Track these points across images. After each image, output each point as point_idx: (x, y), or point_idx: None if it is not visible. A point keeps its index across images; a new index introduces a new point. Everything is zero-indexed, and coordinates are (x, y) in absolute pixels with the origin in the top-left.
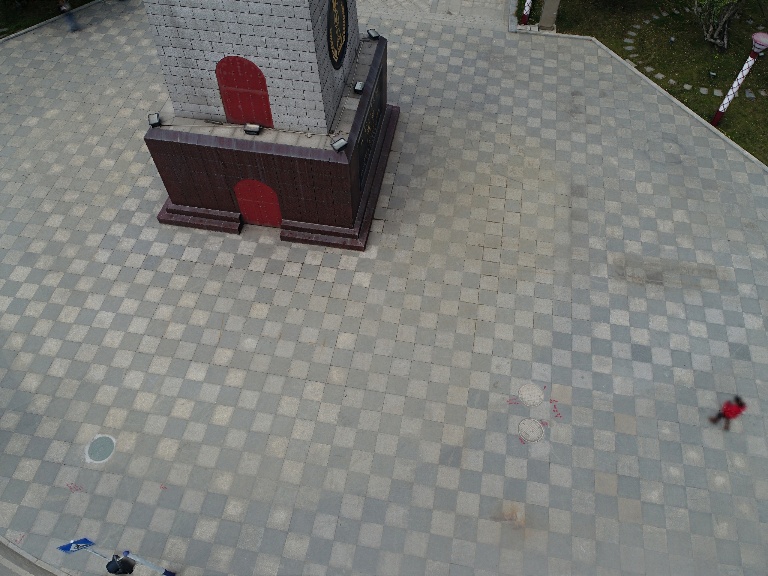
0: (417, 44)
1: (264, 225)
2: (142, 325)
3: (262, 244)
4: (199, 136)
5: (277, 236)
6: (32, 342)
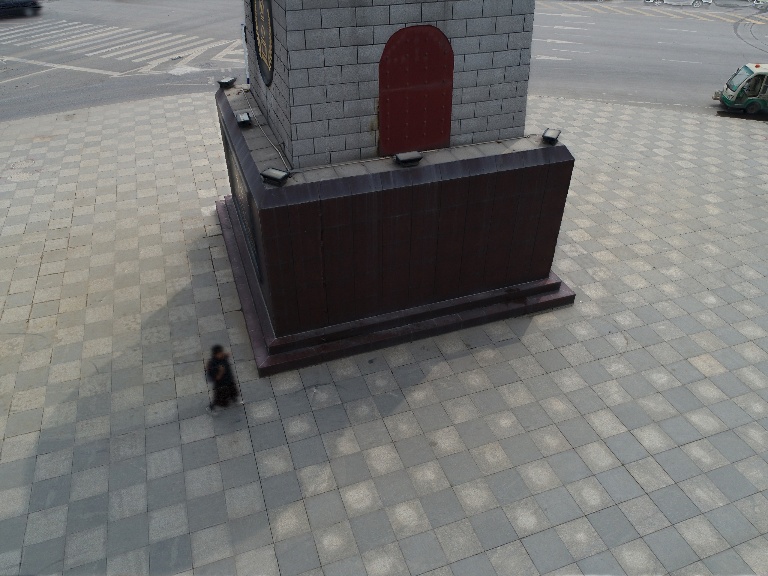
0: None
1: None
2: None
3: None
4: None
5: None
6: None
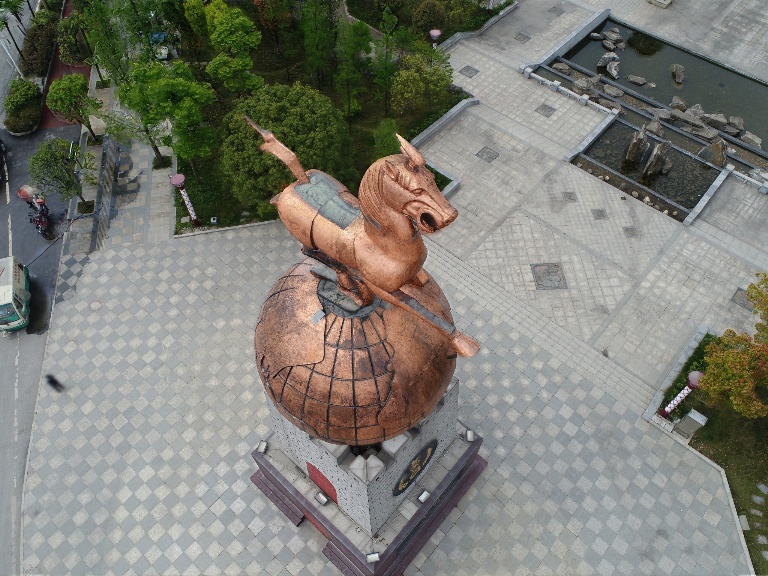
0: (547, 389)
1: None
2: (193, 575)
3: (308, 548)
4: (285, 479)
5: (322, 546)
6: (125, 543)
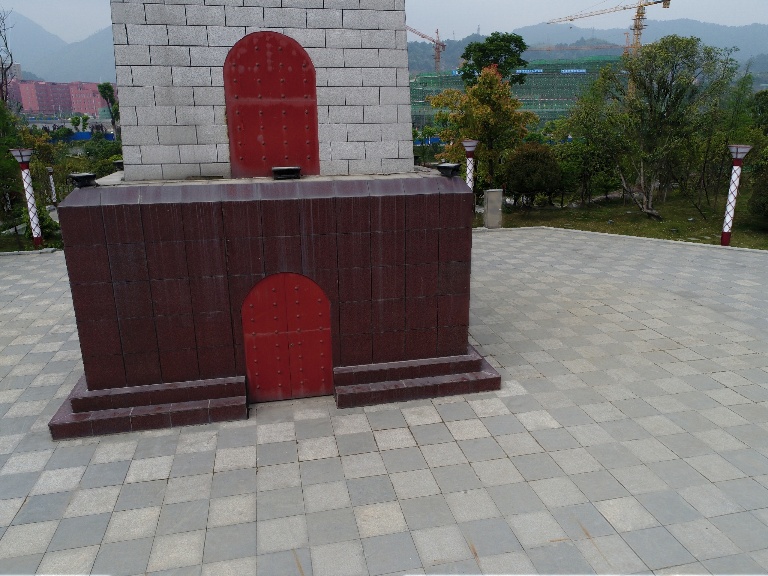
0: None
1: (291, 397)
2: None
3: (304, 421)
4: (184, 188)
5: (326, 405)
6: None
